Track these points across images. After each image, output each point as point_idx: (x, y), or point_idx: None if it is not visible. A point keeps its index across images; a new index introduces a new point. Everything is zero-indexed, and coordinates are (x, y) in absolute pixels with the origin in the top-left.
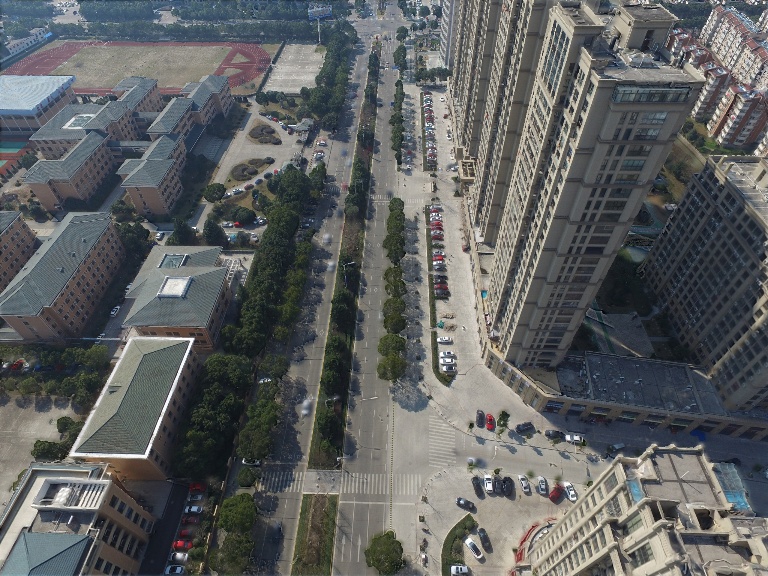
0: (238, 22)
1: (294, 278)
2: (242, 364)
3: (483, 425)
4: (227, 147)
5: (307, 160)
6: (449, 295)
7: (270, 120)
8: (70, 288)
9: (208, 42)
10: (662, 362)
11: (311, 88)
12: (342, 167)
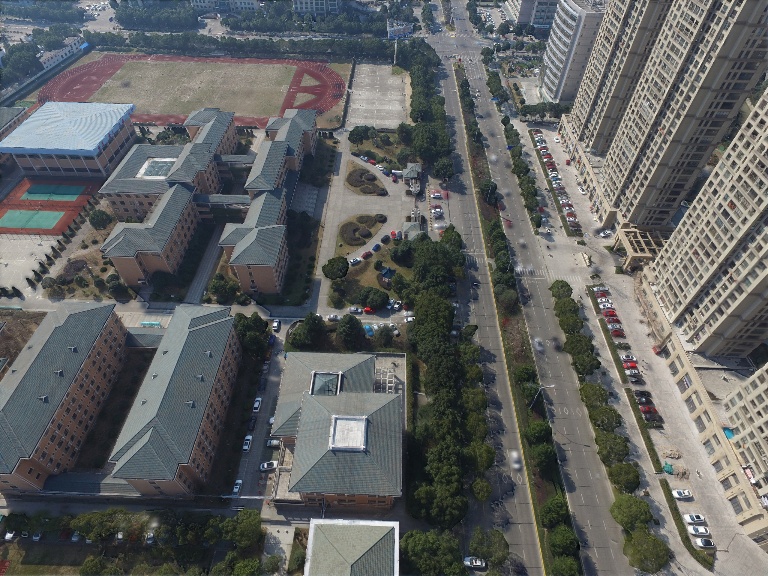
0: (295, 35)
1: (473, 401)
2: (454, 550)
3: None
4: (325, 198)
5: (425, 218)
6: (662, 422)
7: (366, 162)
8: (201, 426)
9: (268, 59)
10: None
11: (408, 124)
12: (469, 228)
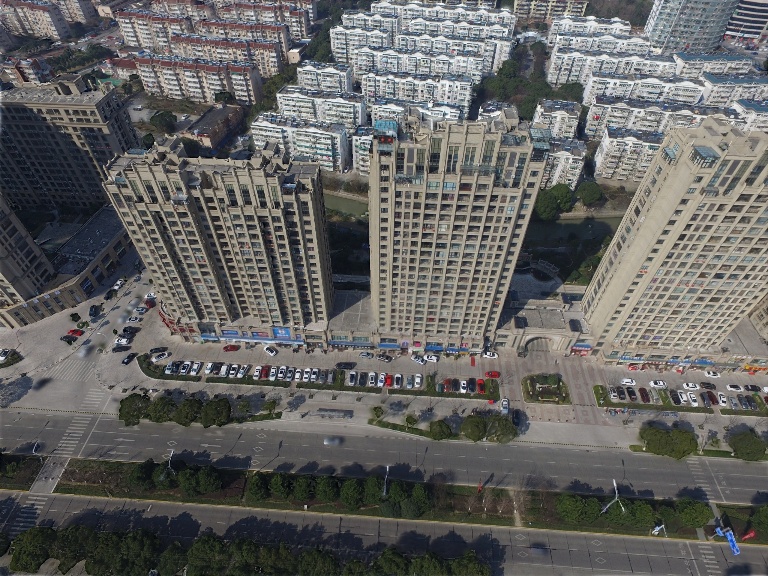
0: None
1: None
2: None
3: (75, 338)
4: None
5: None
6: None
7: None
8: None
9: None
10: (93, 217)
11: None
12: None
